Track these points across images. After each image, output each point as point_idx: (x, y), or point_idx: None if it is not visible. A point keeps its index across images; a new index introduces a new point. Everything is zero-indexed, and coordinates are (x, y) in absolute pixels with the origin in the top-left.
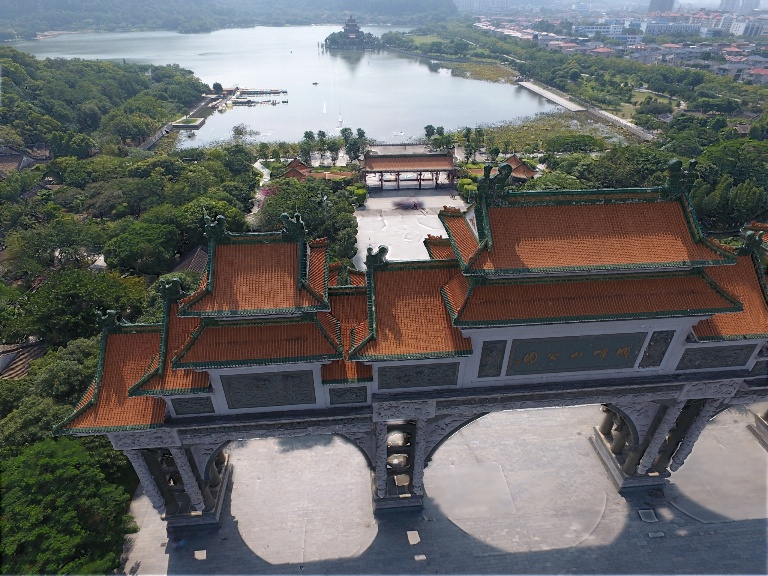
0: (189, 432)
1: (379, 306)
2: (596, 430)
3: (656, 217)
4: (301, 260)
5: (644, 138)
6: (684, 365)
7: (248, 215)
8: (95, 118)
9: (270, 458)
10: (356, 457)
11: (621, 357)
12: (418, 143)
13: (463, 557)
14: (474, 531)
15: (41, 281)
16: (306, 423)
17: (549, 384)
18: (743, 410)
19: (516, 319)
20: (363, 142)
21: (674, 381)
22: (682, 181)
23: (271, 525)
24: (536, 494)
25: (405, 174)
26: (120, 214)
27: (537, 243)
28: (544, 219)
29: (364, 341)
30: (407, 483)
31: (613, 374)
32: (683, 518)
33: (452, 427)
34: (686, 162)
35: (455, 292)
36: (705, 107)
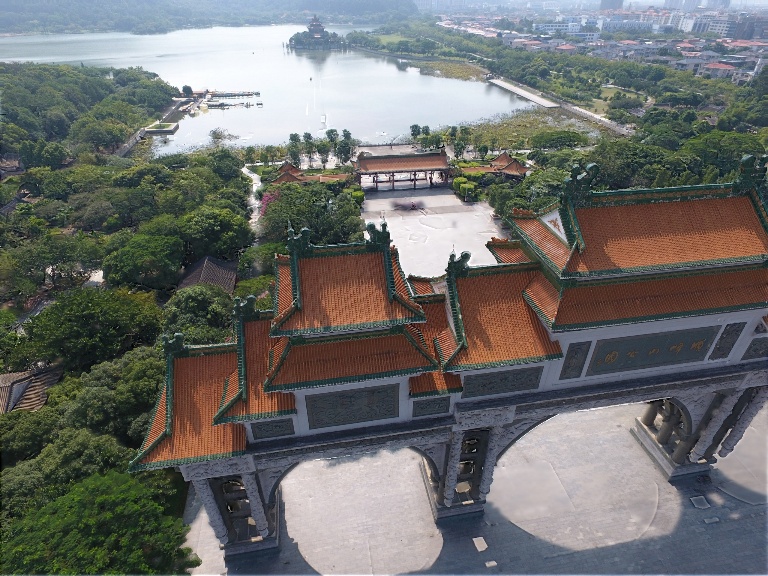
0: (265, 456)
1: (464, 314)
2: (638, 422)
3: (730, 212)
4: (388, 270)
5: (619, 132)
6: (749, 355)
7: (252, 222)
8: (62, 125)
9: (318, 474)
10: (406, 466)
11: (694, 351)
12: (404, 143)
13: (533, 560)
14: (538, 532)
15: (34, 301)
16: (385, 438)
17: (625, 382)
18: None
19: (609, 320)
20: (352, 143)
21: (741, 371)
22: (753, 176)
23: (333, 544)
24: (591, 490)
25: (400, 174)
26: (111, 226)
27: (624, 243)
28: (627, 218)
29: (456, 351)
30: (467, 489)
31: (684, 368)
32: (733, 502)
33: (521, 430)
34: (671, 155)
35: (540, 295)
36: (672, 101)
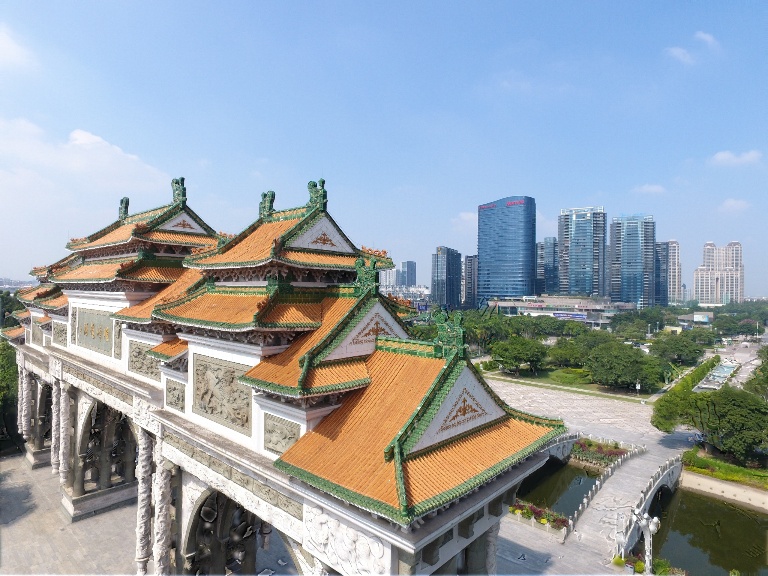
0: None
1: None
2: (79, 499)
3: None
4: None
5: None
6: None
7: None
8: None
9: None
10: None
11: None
12: None
13: None
14: None
15: None
16: None
17: None
18: (6, 472)
19: None
20: None
21: None
22: None
23: None
24: None
25: None
26: None
27: None
28: None
29: None
30: None
31: None
32: None
33: None
34: None
35: None
36: None
